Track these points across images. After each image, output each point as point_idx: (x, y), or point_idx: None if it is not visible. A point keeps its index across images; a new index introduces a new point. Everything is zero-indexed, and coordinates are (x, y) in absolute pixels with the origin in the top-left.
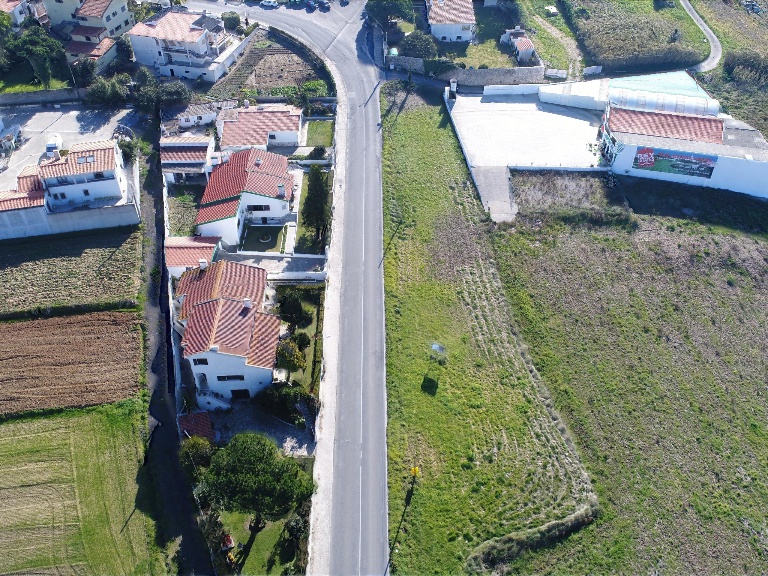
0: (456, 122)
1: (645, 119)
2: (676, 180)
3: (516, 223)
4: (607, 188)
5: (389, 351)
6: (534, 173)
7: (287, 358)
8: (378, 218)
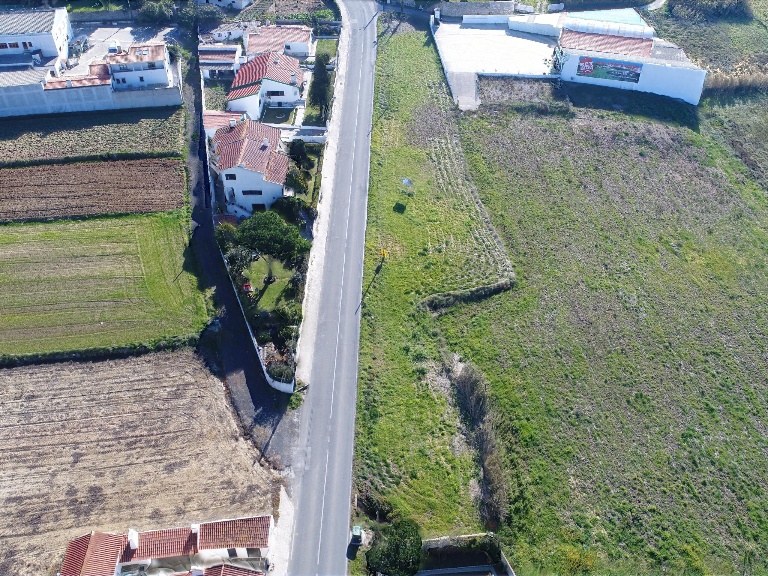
0: (438, 42)
1: (590, 38)
2: (611, 85)
3: (478, 111)
4: (554, 89)
5: (371, 187)
6: (497, 78)
7: (294, 178)
8: (369, 105)
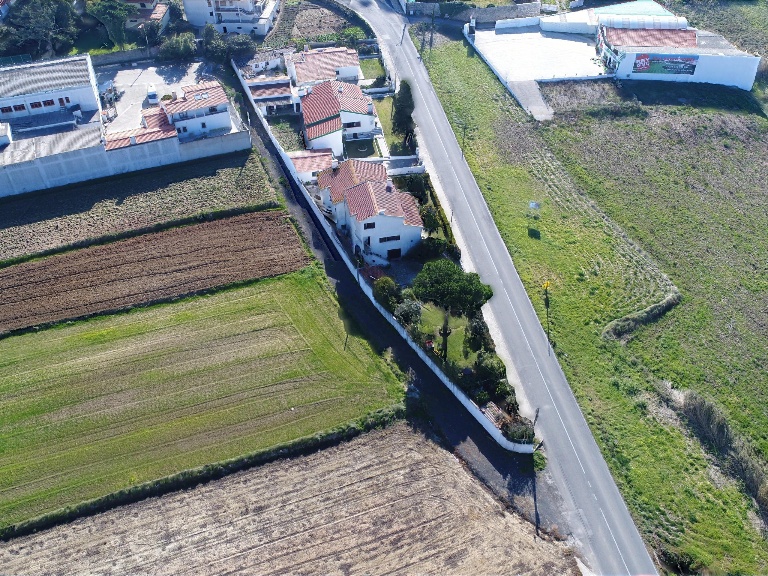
0: (481, 51)
1: (635, 34)
2: (667, 79)
3: (555, 120)
4: (617, 89)
5: (494, 215)
6: (557, 83)
7: (433, 218)
8: (447, 126)
